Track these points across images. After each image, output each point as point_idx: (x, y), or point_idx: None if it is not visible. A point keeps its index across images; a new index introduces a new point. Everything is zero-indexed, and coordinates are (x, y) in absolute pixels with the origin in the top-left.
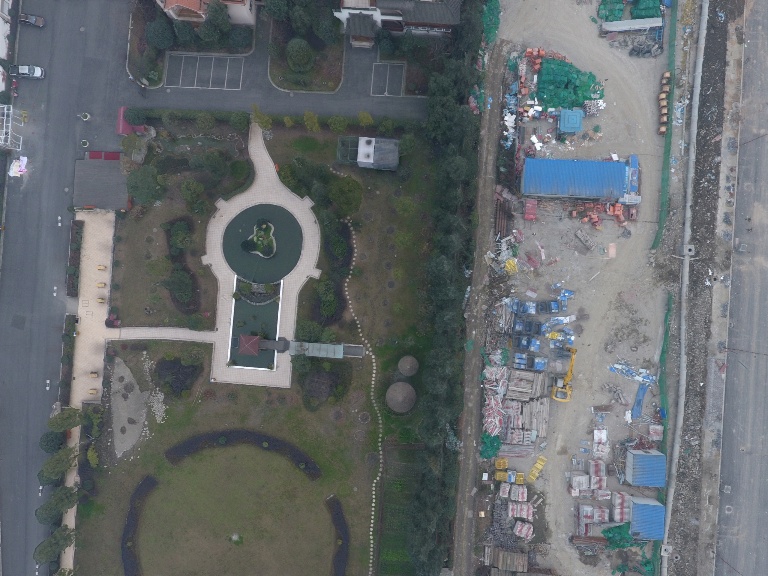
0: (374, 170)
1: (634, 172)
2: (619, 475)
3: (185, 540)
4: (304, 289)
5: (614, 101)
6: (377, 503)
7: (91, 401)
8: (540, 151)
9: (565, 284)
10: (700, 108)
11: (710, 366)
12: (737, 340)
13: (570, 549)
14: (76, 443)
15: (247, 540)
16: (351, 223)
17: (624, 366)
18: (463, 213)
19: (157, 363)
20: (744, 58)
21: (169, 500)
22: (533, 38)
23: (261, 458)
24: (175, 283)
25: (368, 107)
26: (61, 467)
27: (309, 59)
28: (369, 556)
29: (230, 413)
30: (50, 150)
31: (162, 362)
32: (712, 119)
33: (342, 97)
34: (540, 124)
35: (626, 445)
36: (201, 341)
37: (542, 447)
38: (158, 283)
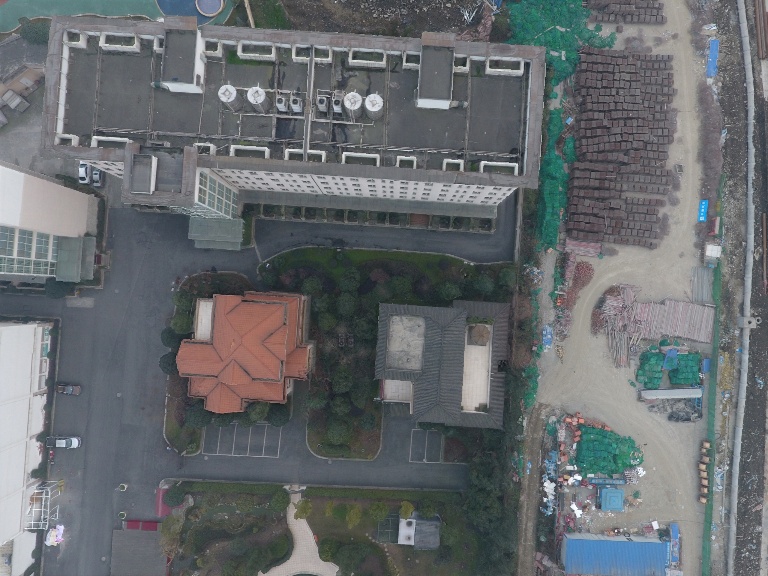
0: None
1: (675, 543)
2: None
3: None
4: None
5: (654, 466)
6: None
7: None
8: (580, 518)
9: None
10: (740, 474)
11: None
12: None
13: None
14: None
15: None
16: None
17: None
18: None
19: None
20: None
21: None
22: (572, 402)
23: None
24: None
25: (407, 474)
26: None
27: None
28: None
29: None
30: (87, 519)
31: None
32: (752, 487)
33: (381, 464)
34: (580, 490)
35: None
36: None
37: None
38: None
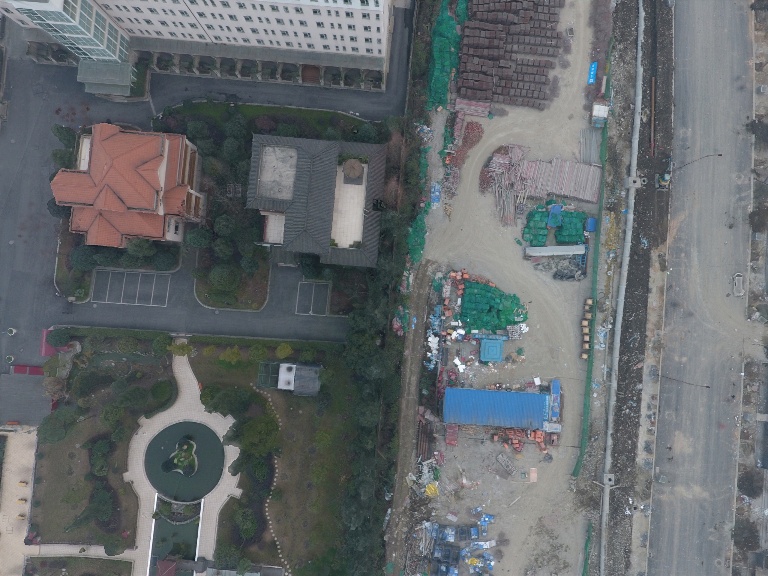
0: None
1: (556, 398)
2: None
3: None
4: (225, 508)
5: (538, 324)
6: None
7: None
8: (463, 373)
9: (486, 508)
10: (623, 333)
11: None
12: (657, 571)
13: None
14: None
15: None
16: None
17: None
18: (383, 439)
19: None
20: (667, 285)
21: None
22: (458, 259)
23: None
24: (89, 518)
25: (293, 326)
26: None
27: (234, 280)
28: None
29: None
30: None
31: None
32: (634, 345)
33: (267, 315)
34: (464, 345)
35: None
36: (120, 559)
37: None
38: (68, 529)
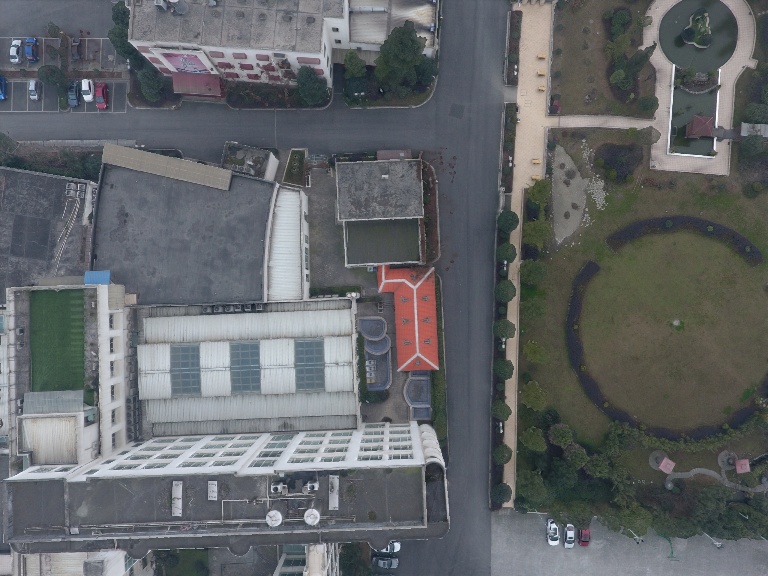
0: None
1: None
2: None
3: (626, 325)
4: (740, 79)
5: None
6: None
7: None
8: None
9: None
10: None
11: None
12: None
13: None
14: None
15: (688, 325)
16: None
17: None
18: None
19: (597, 150)
20: None
21: (610, 286)
22: None
23: (700, 245)
24: None
25: None
26: (551, 229)
27: None
28: None
29: (669, 200)
30: None
31: (604, 148)
32: None
33: None
34: None
35: None
36: None
37: None
38: None
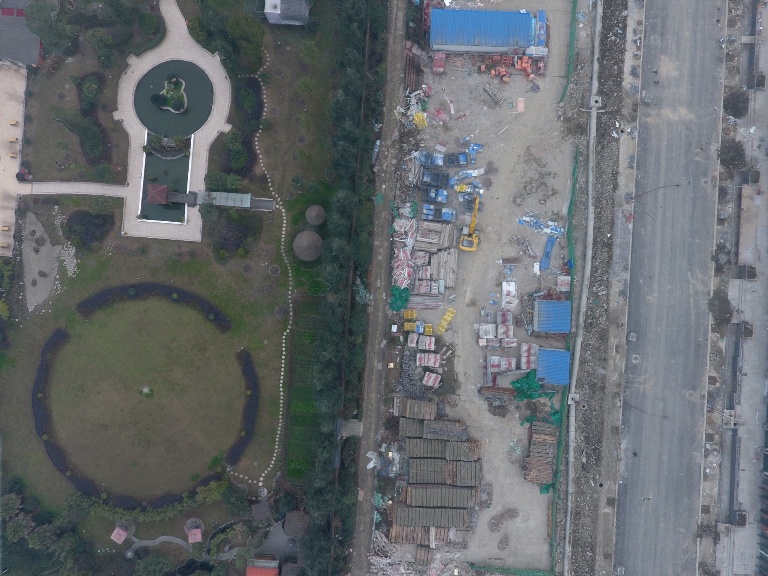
0: (284, 26)
1: (542, 26)
2: (527, 326)
3: (96, 393)
4: (215, 144)
5: None
6: (287, 355)
7: (2, 255)
8: (449, 7)
9: (474, 138)
10: None
11: (617, 217)
12: (644, 191)
13: (479, 400)
14: None
15: (158, 393)
16: (261, 78)
17: (532, 218)
18: (371, 65)
19: (68, 217)
20: None
21: (80, 353)
22: None
23: (172, 311)
24: (79, 126)
25: None
26: None
27: None
28: (279, 408)
29: (141, 267)
30: None
31: (73, 215)
32: None
33: None
34: None
35: (534, 296)
36: (112, 195)
37: (451, 299)
38: (57, 118)
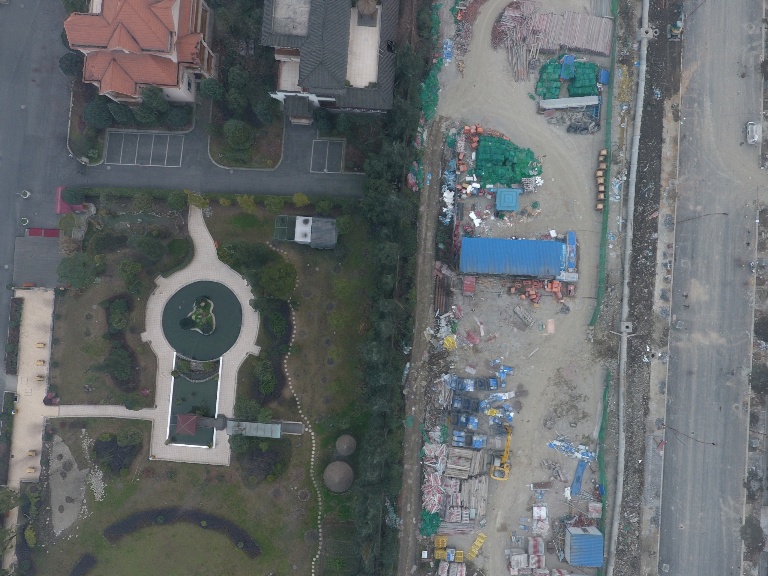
0: None
1: (572, 249)
2: (558, 552)
3: None
4: (243, 366)
5: (552, 177)
6: None
7: (29, 480)
8: (479, 227)
9: (504, 360)
10: (637, 184)
11: (648, 443)
12: (675, 417)
13: None
14: (12, 524)
15: None
16: (290, 300)
17: (563, 443)
18: (401, 291)
19: (96, 441)
20: (680, 135)
21: None
22: (472, 115)
23: (200, 536)
24: (109, 366)
25: (308, 184)
26: None
27: (248, 137)
28: None
29: (169, 491)
30: None
31: (100, 440)
32: (649, 196)
33: (282, 174)
34: (479, 200)
35: (565, 522)
36: (140, 419)
37: (481, 524)
38: (89, 370)
